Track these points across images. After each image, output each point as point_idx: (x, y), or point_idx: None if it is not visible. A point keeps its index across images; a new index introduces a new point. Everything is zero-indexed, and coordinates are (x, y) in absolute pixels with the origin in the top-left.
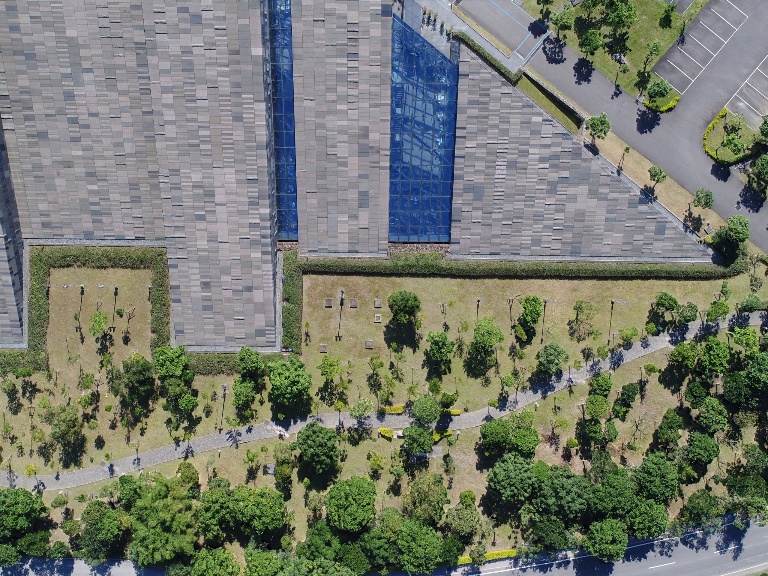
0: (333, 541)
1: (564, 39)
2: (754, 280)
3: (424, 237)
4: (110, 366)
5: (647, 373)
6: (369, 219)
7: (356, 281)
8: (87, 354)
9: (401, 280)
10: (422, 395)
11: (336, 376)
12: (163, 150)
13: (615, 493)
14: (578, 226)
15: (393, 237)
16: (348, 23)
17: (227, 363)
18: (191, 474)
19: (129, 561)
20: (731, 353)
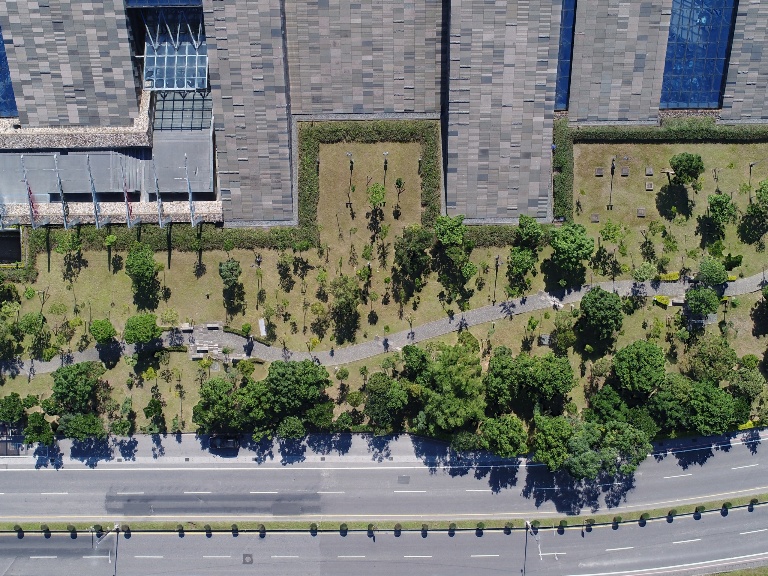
0: (621, 405)
1: None
2: None
3: (693, 103)
4: (381, 241)
5: None
6: (643, 84)
7: (627, 149)
8: (358, 229)
9: (672, 147)
10: (706, 257)
11: (608, 245)
12: (457, 8)
13: None
14: None
15: (662, 104)
16: None
17: (500, 234)
18: (475, 342)
19: (407, 435)
20: None
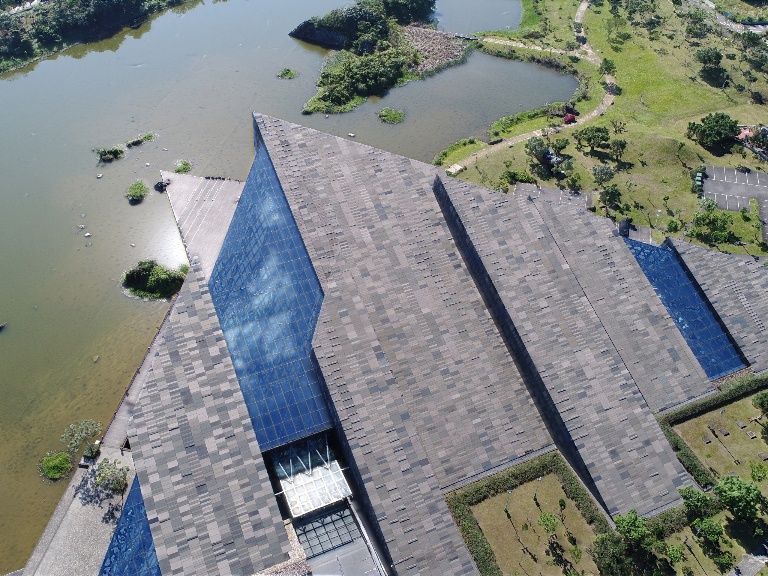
0: None
1: None
2: None
3: (728, 371)
4: None
5: None
6: (686, 368)
7: (712, 416)
8: (546, 570)
9: (741, 402)
10: None
11: (763, 492)
12: (534, 353)
13: None
14: None
15: None
16: (598, 247)
17: (672, 519)
18: None
19: None
20: None
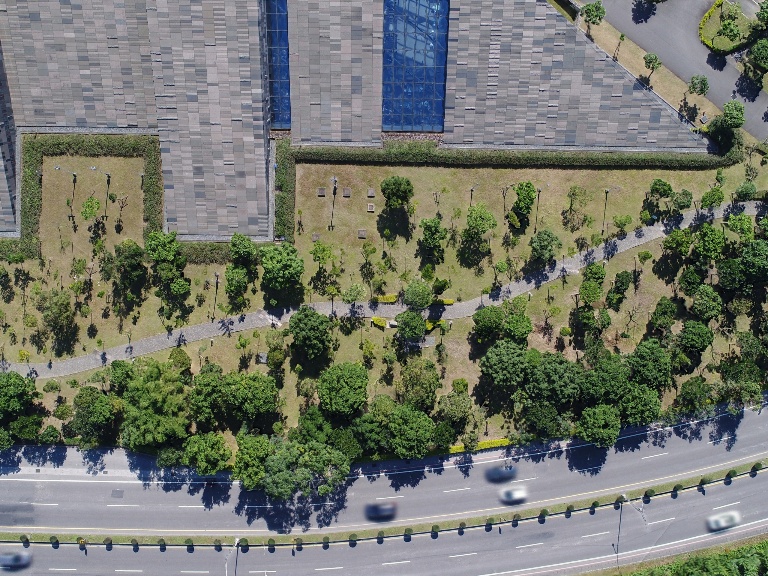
0: (325, 426)
1: None
2: (750, 170)
3: (418, 126)
4: (103, 255)
5: (641, 260)
6: (362, 106)
7: (349, 170)
8: (80, 243)
9: (394, 169)
10: (415, 281)
11: (329, 265)
12: (155, 26)
13: (608, 377)
14: (572, 114)
15: (386, 126)
16: None
17: (220, 251)
18: (183, 359)
19: (121, 449)
20: (726, 243)
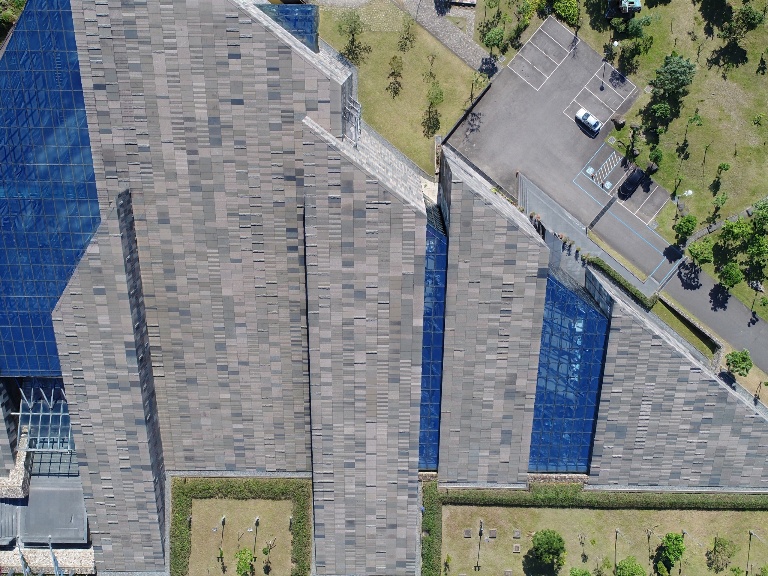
0: None
1: (700, 264)
2: None
3: (562, 467)
4: None
5: None
6: (510, 454)
7: (495, 512)
8: None
9: (540, 511)
10: None
11: None
12: (318, 407)
13: None
14: (718, 461)
15: (531, 467)
16: (503, 284)
17: None
18: None
19: None
20: None
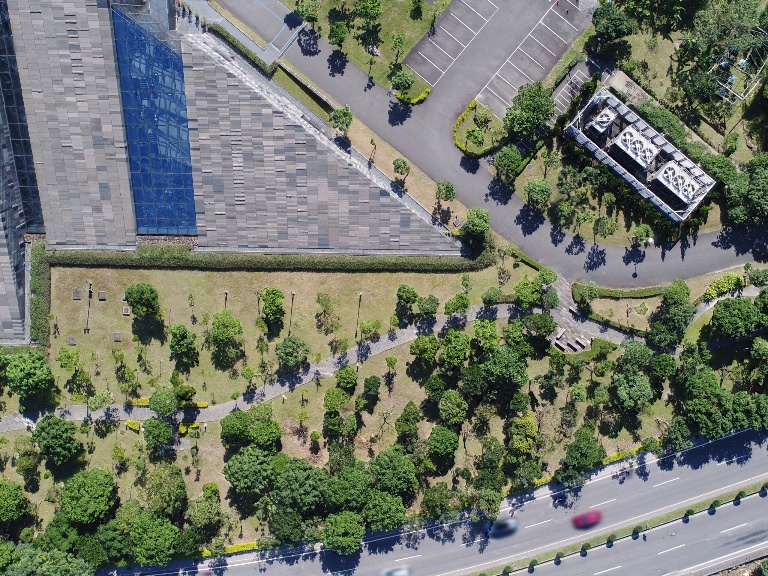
0: (71, 533)
1: (319, 31)
2: (502, 273)
3: (173, 229)
4: None
5: None
6: (113, 211)
7: (104, 273)
8: None
9: (149, 272)
10: (160, 387)
11: (84, 368)
12: None
13: (347, 485)
14: (322, 218)
15: (142, 229)
16: (65, 15)
17: None
18: None
19: None
20: (479, 346)
